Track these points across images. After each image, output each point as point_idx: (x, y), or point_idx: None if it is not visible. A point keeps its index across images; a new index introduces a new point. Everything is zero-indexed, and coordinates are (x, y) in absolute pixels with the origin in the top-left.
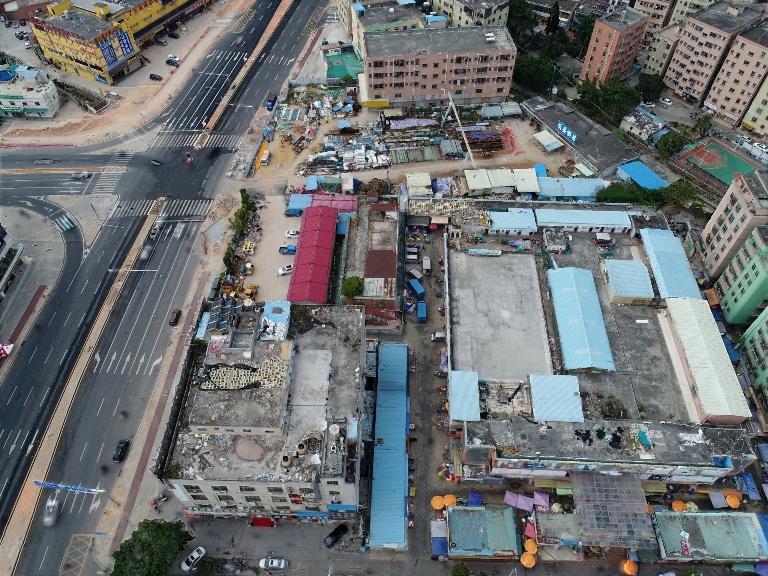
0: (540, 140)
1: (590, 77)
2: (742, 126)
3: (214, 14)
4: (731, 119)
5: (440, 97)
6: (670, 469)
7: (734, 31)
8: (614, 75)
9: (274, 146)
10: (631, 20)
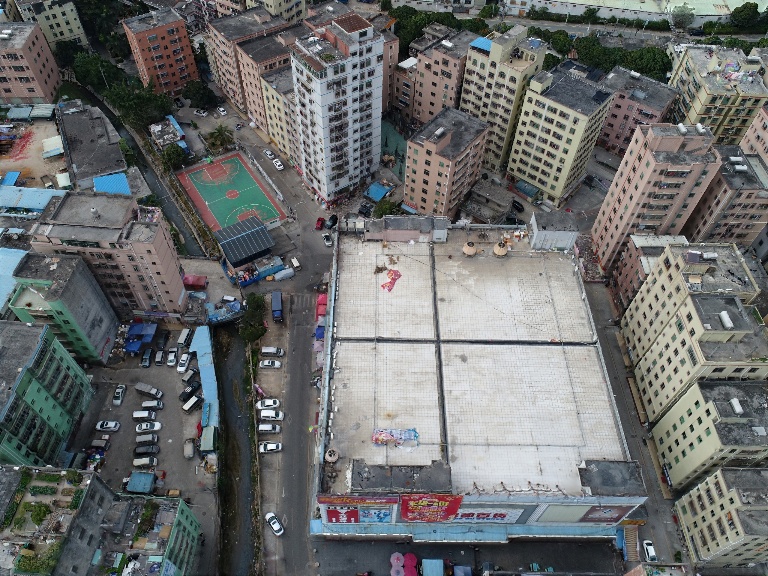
0: (45, 146)
1: (145, 81)
2: None
3: None
4: None
5: None
6: None
7: (238, 40)
8: (167, 80)
9: None
10: (163, 23)
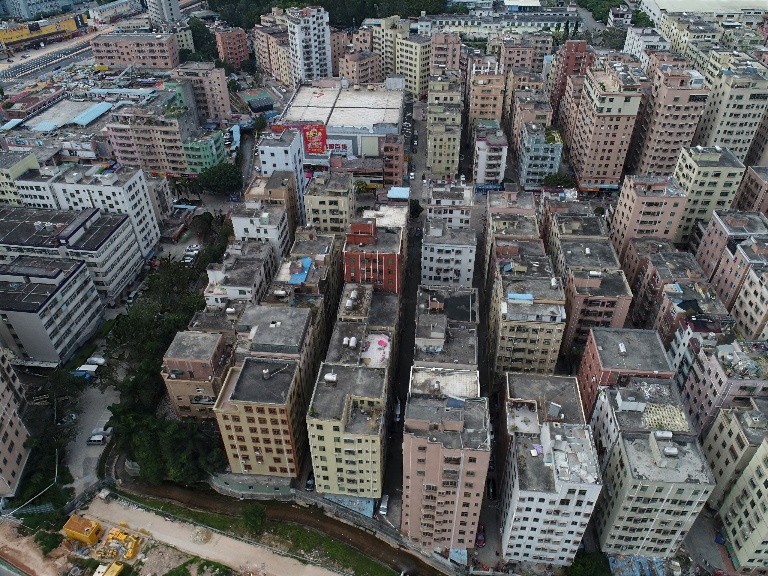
0: None
1: None
2: (283, 83)
3: (67, 42)
4: (280, 80)
5: (135, 66)
6: (69, 144)
7: None
8: (233, 62)
9: (43, 83)
10: None
